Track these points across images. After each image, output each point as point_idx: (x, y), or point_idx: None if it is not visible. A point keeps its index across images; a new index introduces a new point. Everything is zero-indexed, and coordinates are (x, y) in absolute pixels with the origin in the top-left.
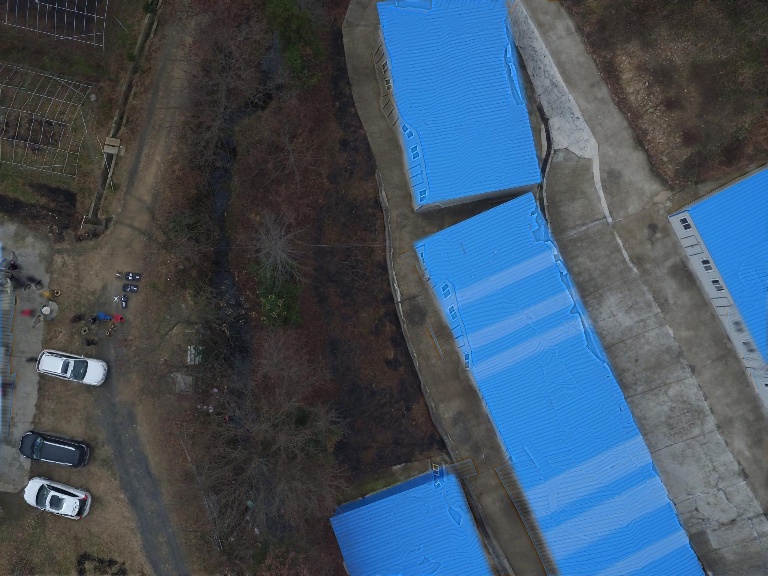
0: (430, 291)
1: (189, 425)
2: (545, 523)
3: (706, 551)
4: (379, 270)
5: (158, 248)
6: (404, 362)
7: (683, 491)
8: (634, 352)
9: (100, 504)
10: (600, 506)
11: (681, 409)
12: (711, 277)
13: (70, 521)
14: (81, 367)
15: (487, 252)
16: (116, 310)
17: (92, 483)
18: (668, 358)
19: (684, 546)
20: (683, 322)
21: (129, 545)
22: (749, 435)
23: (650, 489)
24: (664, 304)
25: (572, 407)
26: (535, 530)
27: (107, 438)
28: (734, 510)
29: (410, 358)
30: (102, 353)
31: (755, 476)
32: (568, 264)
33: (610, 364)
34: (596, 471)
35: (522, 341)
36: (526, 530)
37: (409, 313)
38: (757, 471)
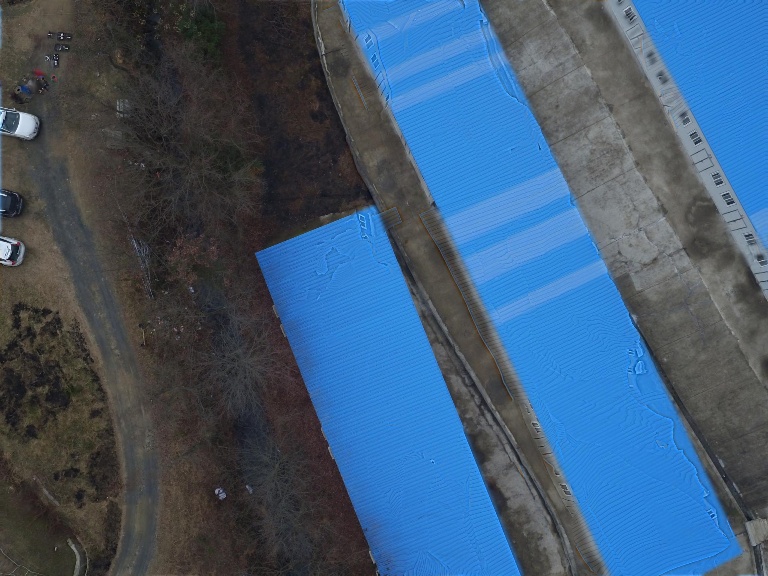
0: (354, 44)
1: (120, 179)
2: (467, 261)
3: (630, 295)
4: (305, 28)
5: (89, 9)
6: (330, 116)
7: (606, 235)
8: (555, 98)
9: (34, 256)
10: (519, 237)
11: (601, 150)
12: (624, 7)
13: (5, 272)
14: (13, 119)
15: (411, 10)
16: (48, 70)
17: (26, 235)
18: (587, 99)
19: (602, 276)
20: (601, 62)
21: (62, 294)
22: (668, 171)
23: (568, 220)
24: (582, 45)
25: (470, 85)
26: (458, 270)
27: (40, 192)
28: (655, 248)
29: (336, 112)
30: (35, 110)
31: (674, 211)
32: (489, 15)
33: (532, 113)
34: (496, 152)
35: (441, 80)
36: (449, 271)
37: (333, 65)
38: (676, 207)
